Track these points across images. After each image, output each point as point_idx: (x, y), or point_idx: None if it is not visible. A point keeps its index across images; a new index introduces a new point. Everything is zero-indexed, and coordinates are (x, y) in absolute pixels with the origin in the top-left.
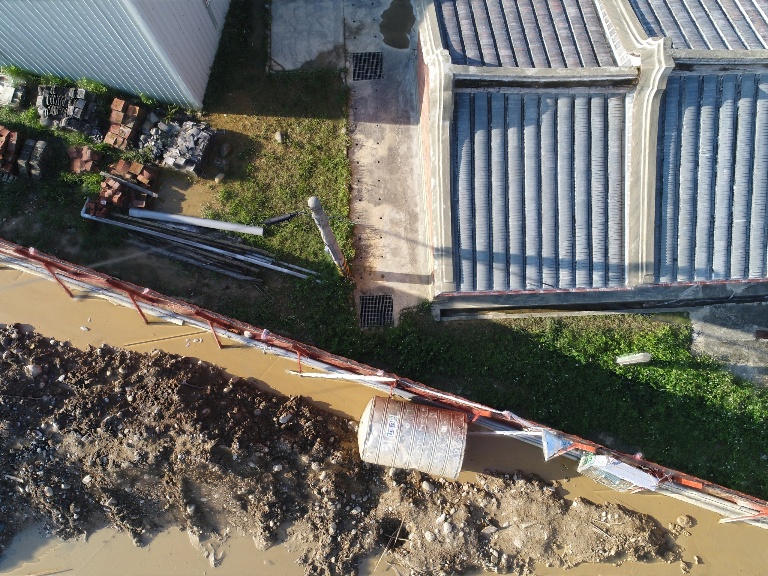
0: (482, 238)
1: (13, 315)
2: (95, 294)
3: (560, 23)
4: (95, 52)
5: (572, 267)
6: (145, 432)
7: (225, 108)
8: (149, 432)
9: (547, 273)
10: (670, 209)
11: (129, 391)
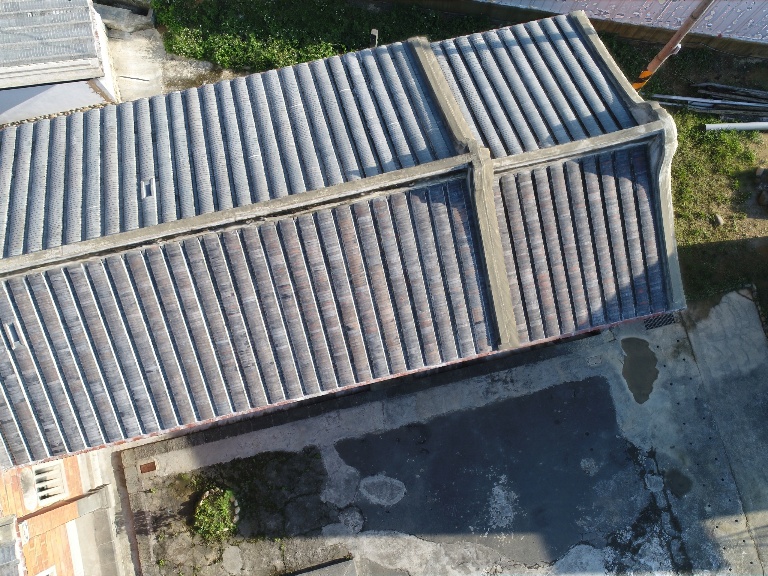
0: (564, 47)
1: None
2: None
3: (541, 254)
4: None
5: (476, 47)
6: None
7: None
8: None
9: (496, 39)
10: (413, 84)
11: None
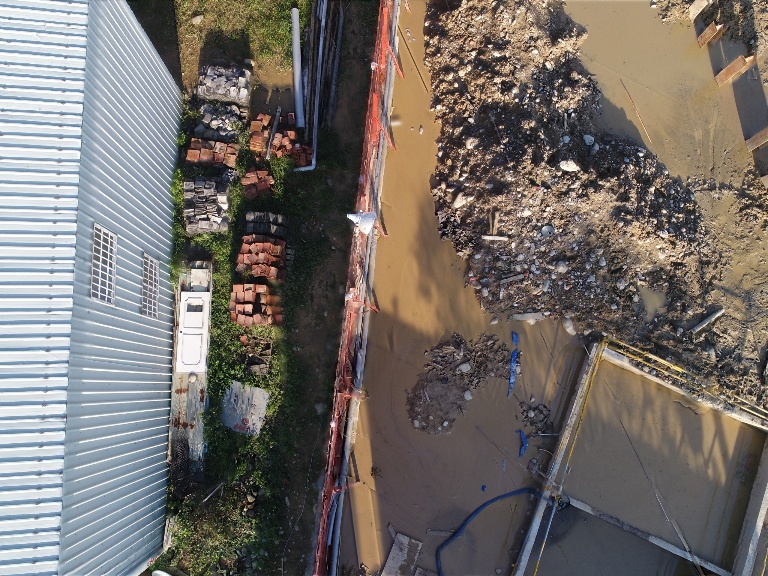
0: None
1: (424, 198)
2: (388, 122)
3: None
4: (150, 123)
5: None
6: (500, 8)
7: (175, 76)
8: (499, 6)
9: None
10: None
11: (467, 58)
